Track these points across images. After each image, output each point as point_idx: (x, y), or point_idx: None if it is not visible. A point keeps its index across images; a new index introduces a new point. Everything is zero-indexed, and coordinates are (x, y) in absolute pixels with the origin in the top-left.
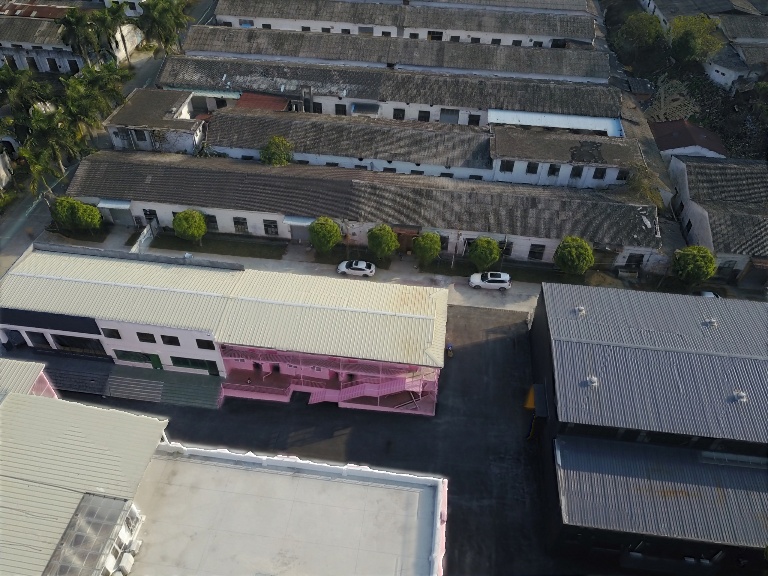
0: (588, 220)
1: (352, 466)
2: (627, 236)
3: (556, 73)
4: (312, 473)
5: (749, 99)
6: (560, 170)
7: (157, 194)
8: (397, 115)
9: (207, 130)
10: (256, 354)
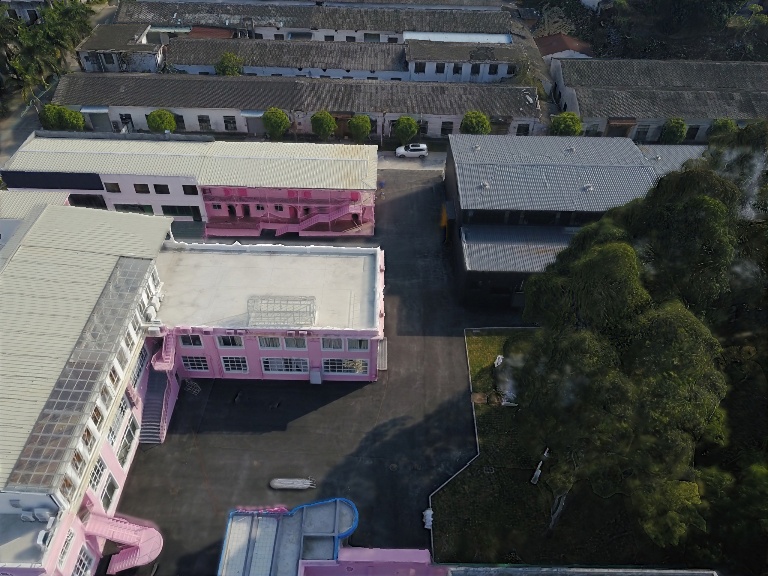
0: (485, 100)
1: (314, 246)
2: (515, 110)
3: (458, 4)
4: (284, 253)
5: (611, 16)
6: (462, 69)
7: (131, 99)
8: None
9: (167, 52)
10: (231, 195)
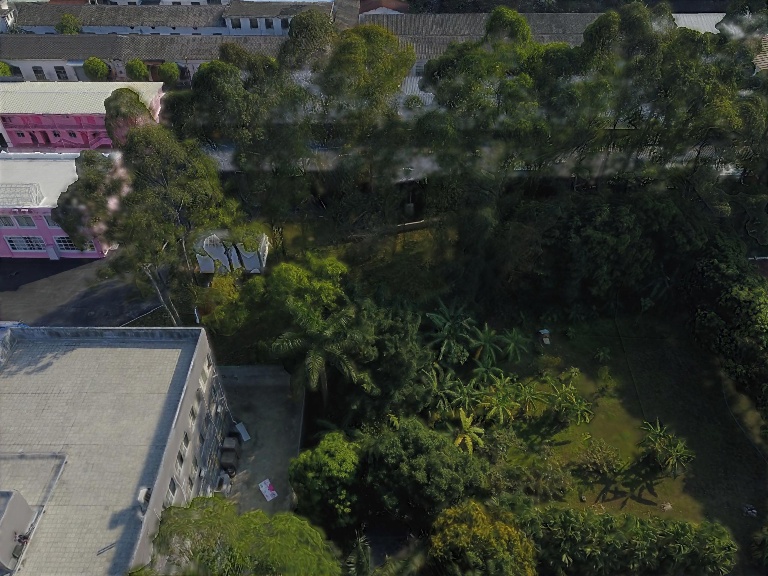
0: None
1: None
2: None
3: None
4: (42, 159)
5: None
6: (273, 23)
7: None
8: None
9: (17, 16)
10: (26, 123)
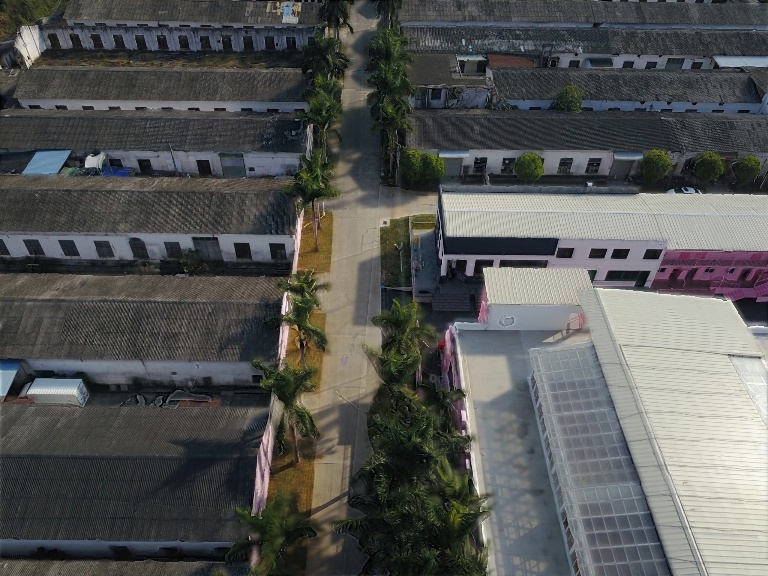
0: None
1: None
2: None
3: (748, 23)
4: None
5: None
6: None
7: (491, 142)
8: (625, 67)
9: (495, 86)
10: (694, 259)
